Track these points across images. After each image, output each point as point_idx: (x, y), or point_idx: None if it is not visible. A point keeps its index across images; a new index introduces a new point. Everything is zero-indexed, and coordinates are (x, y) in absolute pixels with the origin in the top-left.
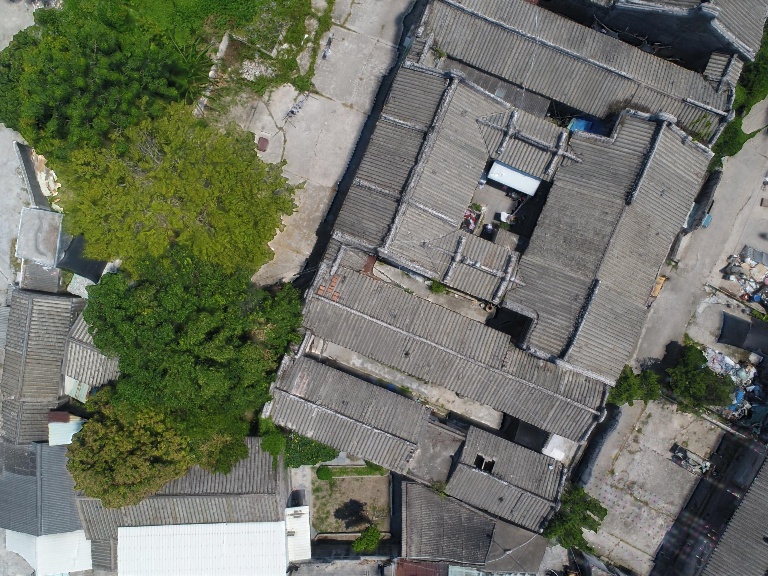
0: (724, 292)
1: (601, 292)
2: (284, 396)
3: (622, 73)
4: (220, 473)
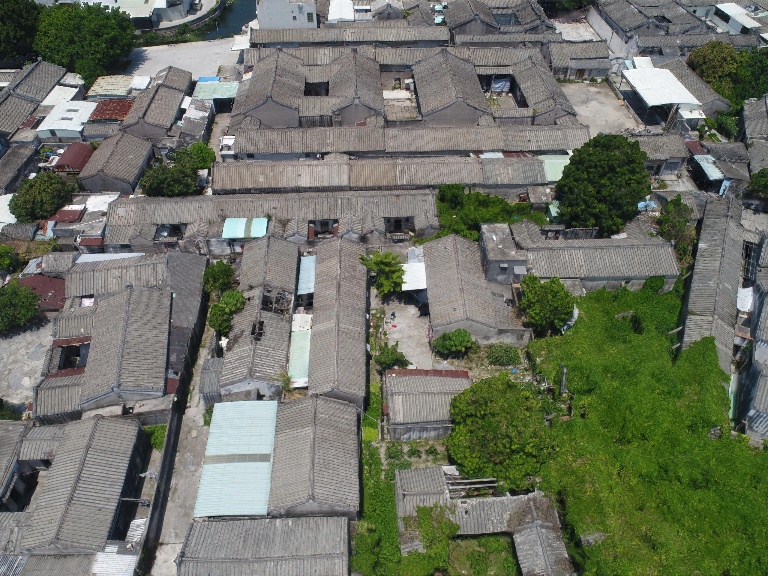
0: None
1: None
2: None
3: None
4: (713, 89)
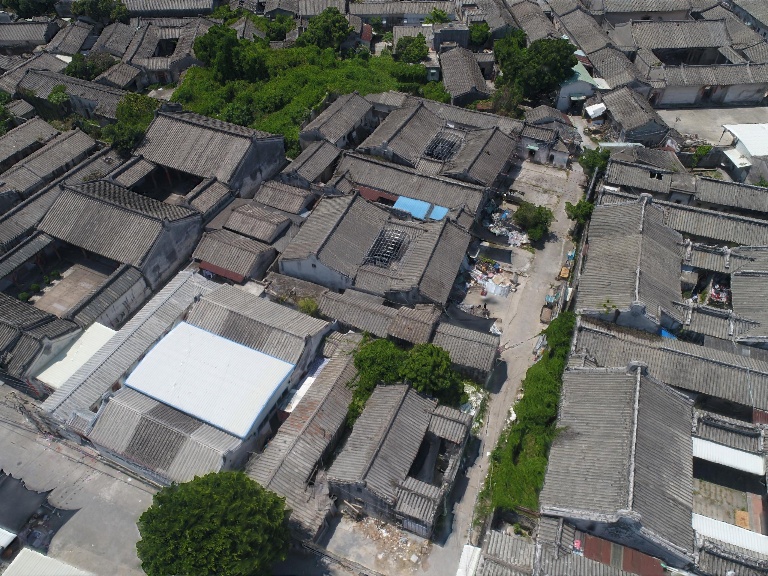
0: None
1: (632, 233)
2: None
3: (671, 349)
4: None
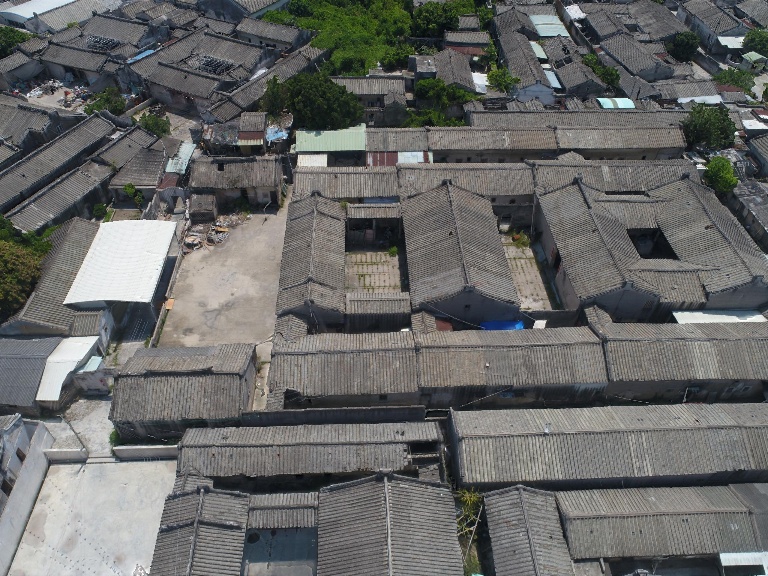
0: None
1: None
2: (14, 218)
3: None
4: (50, 249)
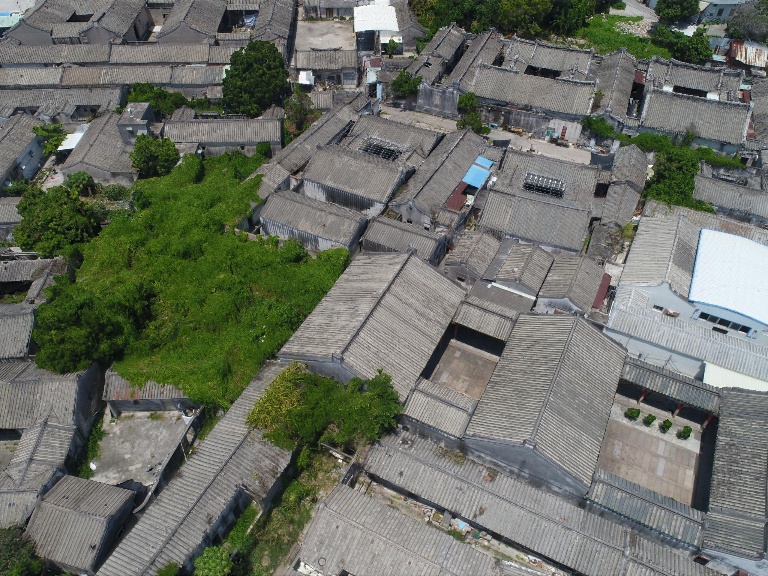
0: None
1: (513, 79)
2: None
3: None
4: (417, 20)
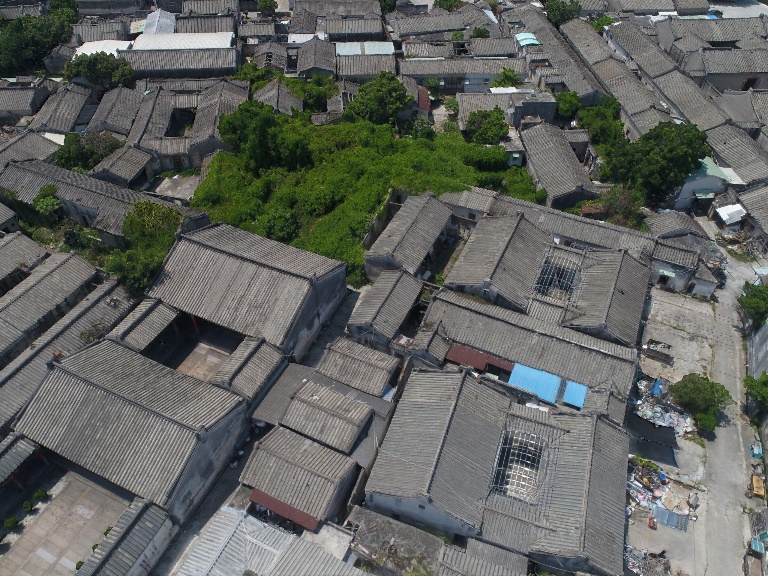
0: (686, 486)
1: None
2: None
3: None
4: None
